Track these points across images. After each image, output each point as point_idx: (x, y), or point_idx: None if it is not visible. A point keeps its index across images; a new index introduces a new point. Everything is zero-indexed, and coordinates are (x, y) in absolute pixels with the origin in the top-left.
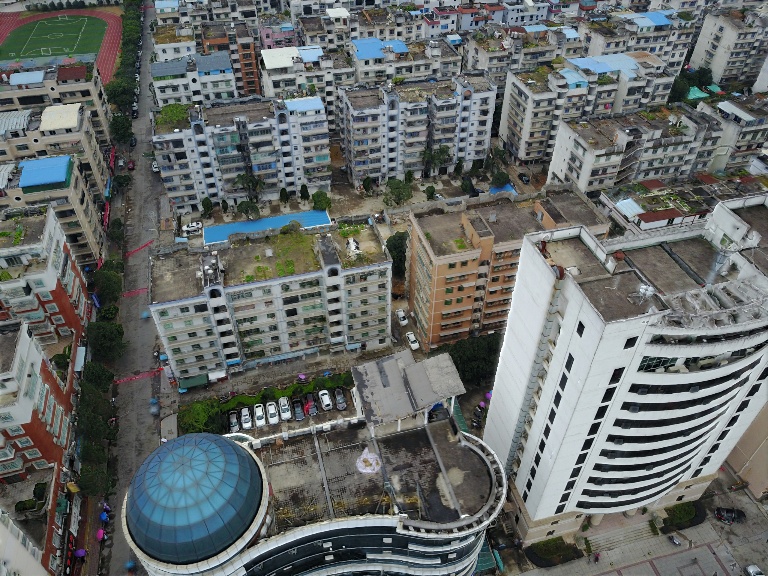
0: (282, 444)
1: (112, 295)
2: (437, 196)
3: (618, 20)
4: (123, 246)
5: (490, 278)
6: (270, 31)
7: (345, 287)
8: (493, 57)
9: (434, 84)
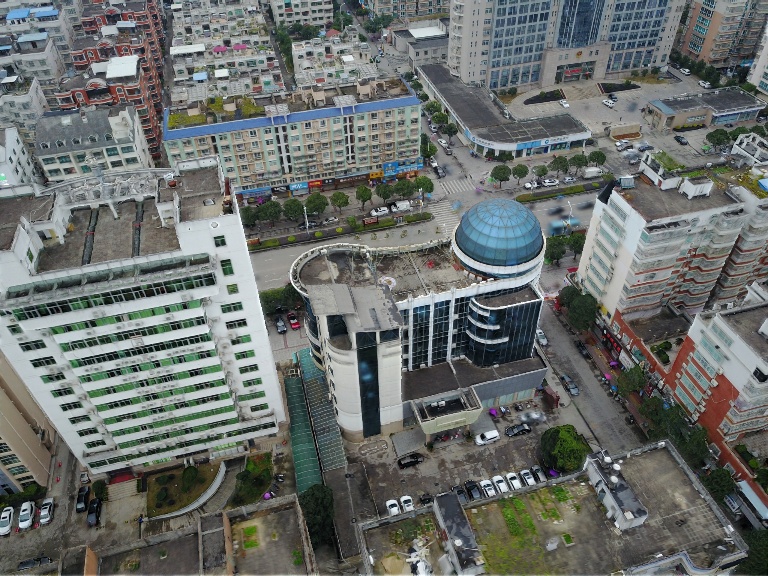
0: None
1: None
2: None
3: None
4: None
5: None
6: None
7: None
8: None
9: None
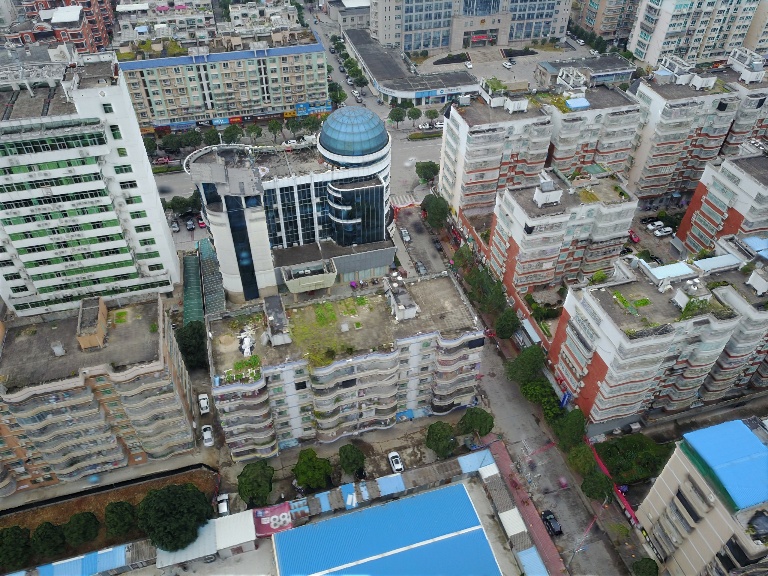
0: None
1: None
2: None
3: None
4: None
5: None
6: None
7: None
8: None
9: None
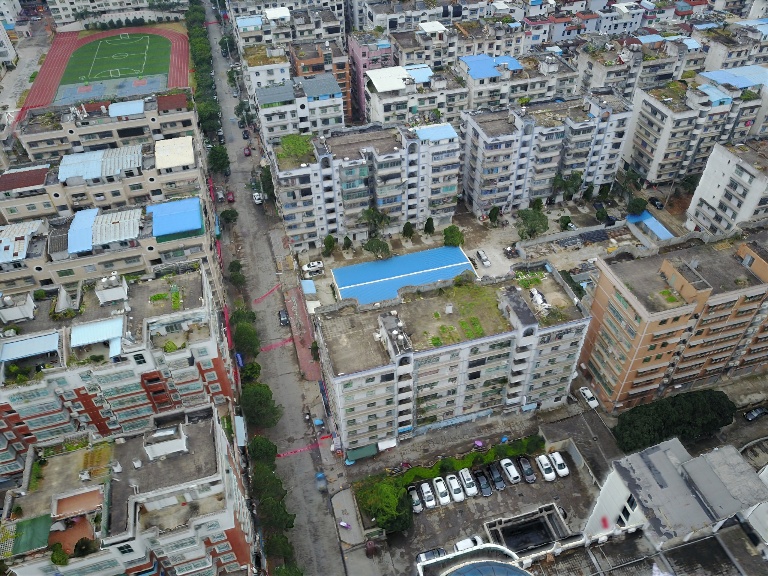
0: (553, 561)
1: (253, 351)
2: (570, 226)
3: (738, 27)
4: (242, 290)
5: (695, 332)
6: (367, 49)
7: (537, 347)
8: (611, 72)
9: (563, 105)
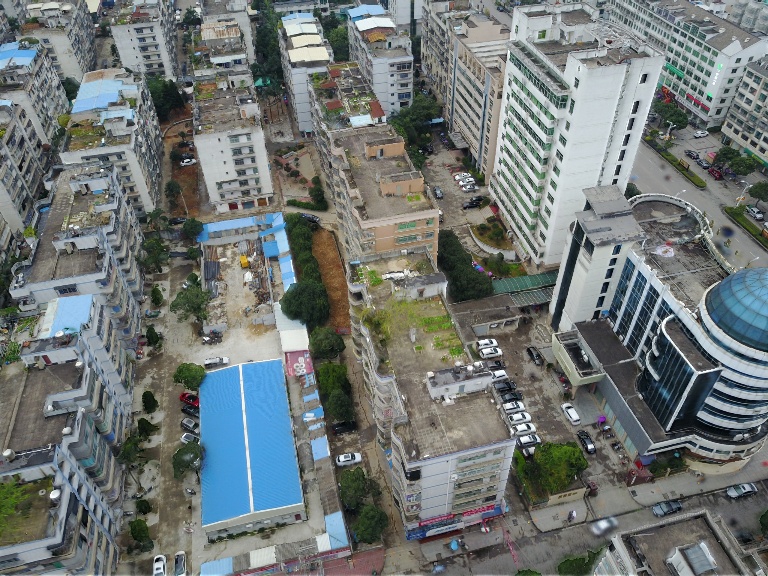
0: None
1: None
2: None
3: (0, 73)
4: None
5: None
6: None
7: None
8: None
9: (58, 207)
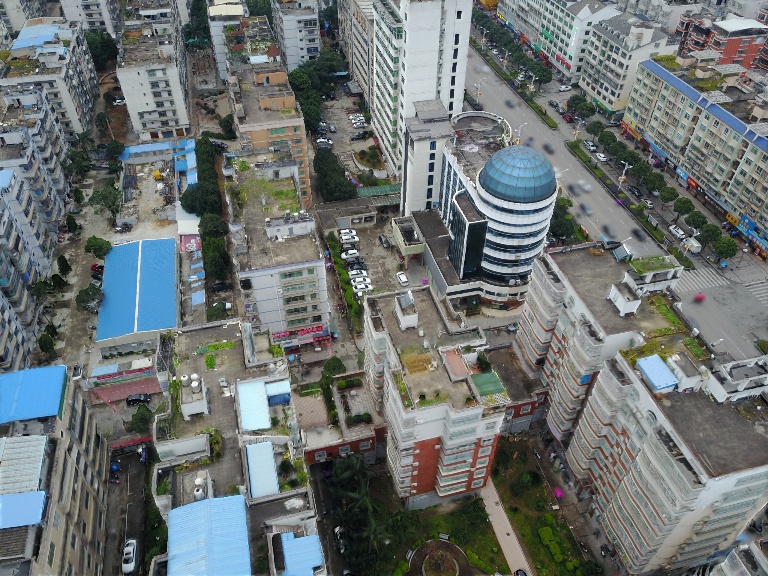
0: None
1: None
2: None
3: None
4: None
5: None
6: None
7: None
8: None
9: None
